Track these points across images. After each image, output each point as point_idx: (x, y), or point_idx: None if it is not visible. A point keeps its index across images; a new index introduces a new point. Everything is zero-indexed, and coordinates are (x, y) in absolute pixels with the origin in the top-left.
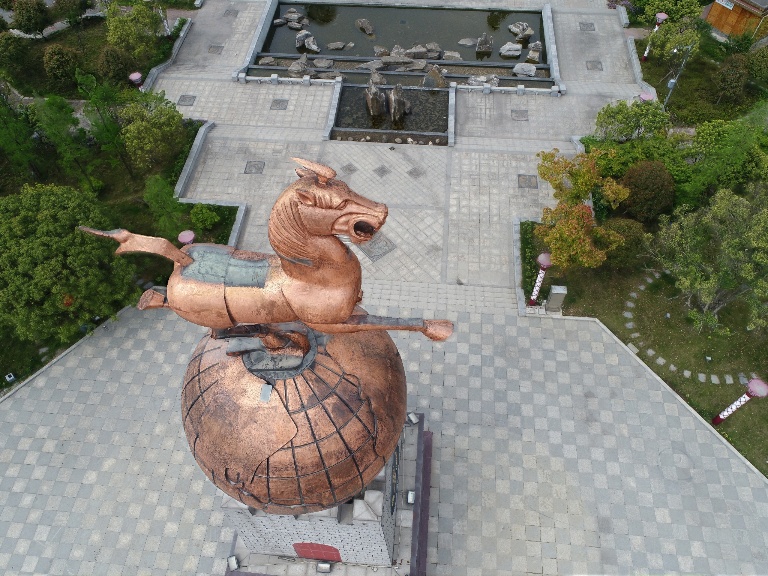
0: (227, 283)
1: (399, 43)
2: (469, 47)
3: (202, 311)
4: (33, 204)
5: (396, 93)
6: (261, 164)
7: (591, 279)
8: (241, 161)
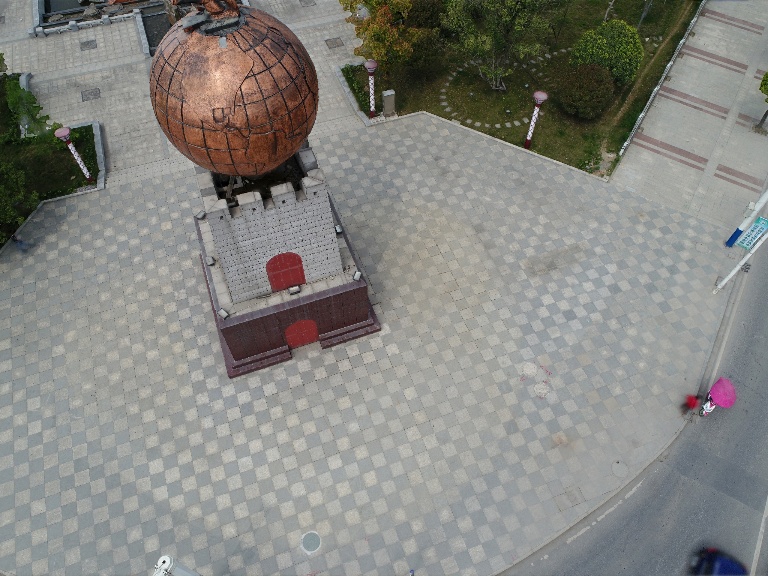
0: None
1: None
2: None
3: None
4: None
5: None
6: (96, 90)
7: (409, 89)
8: (75, 93)
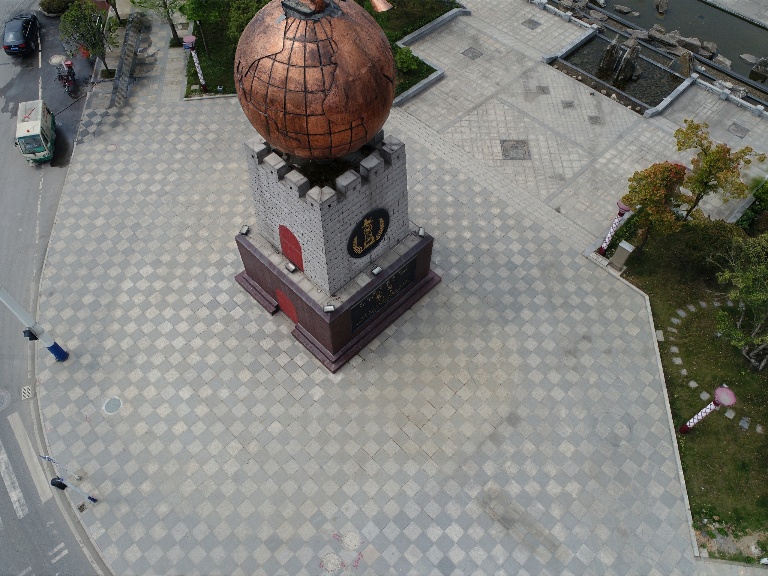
0: None
1: (682, 31)
2: (748, 63)
3: None
4: None
5: (631, 53)
6: (479, 54)
7: (673, 269)
8: (466, 45)
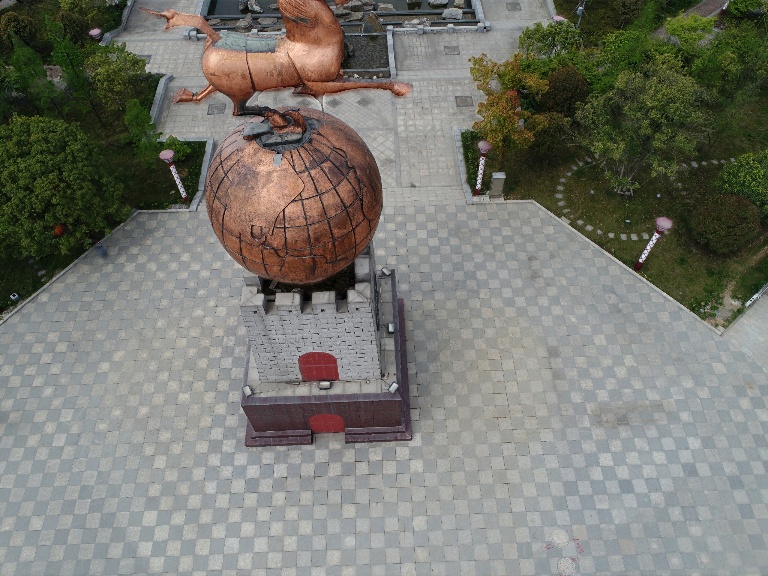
0: (248, 51)
1: None
2: None
3: (231, 74)
4: (24, 131)
5: None
6: (222, 106)
7: (526, 171)
8: (203, 105)
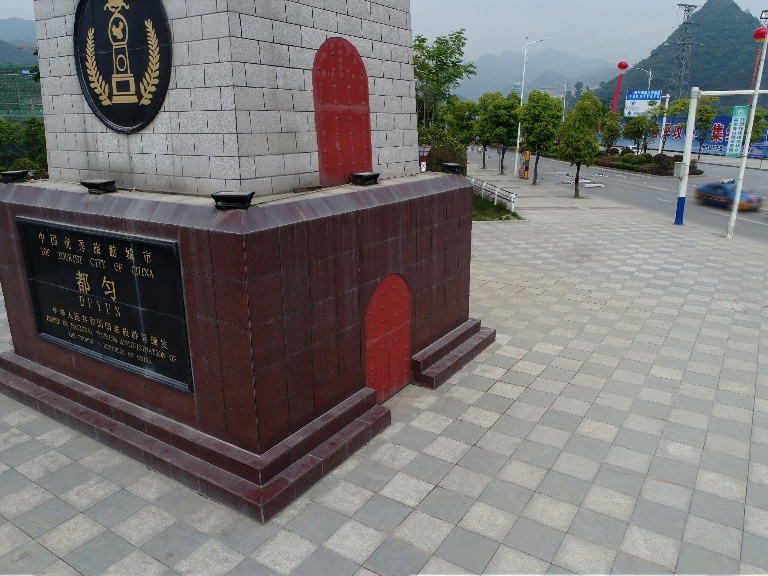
0: None
1: None
2: None
3: None
4: None
5: None
6: None
7: None
8: None
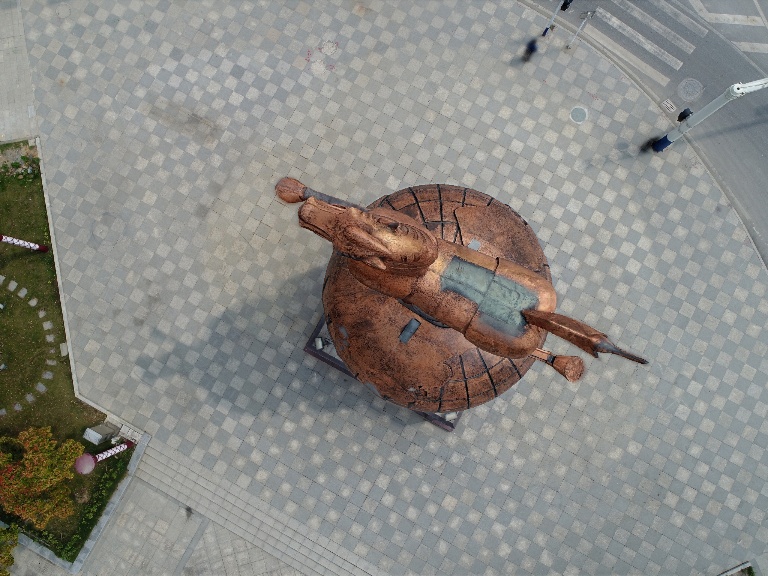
0: (492, 274)
1: None
2: None
3: None
4: None
5: None
6: None
7: None
8: None
